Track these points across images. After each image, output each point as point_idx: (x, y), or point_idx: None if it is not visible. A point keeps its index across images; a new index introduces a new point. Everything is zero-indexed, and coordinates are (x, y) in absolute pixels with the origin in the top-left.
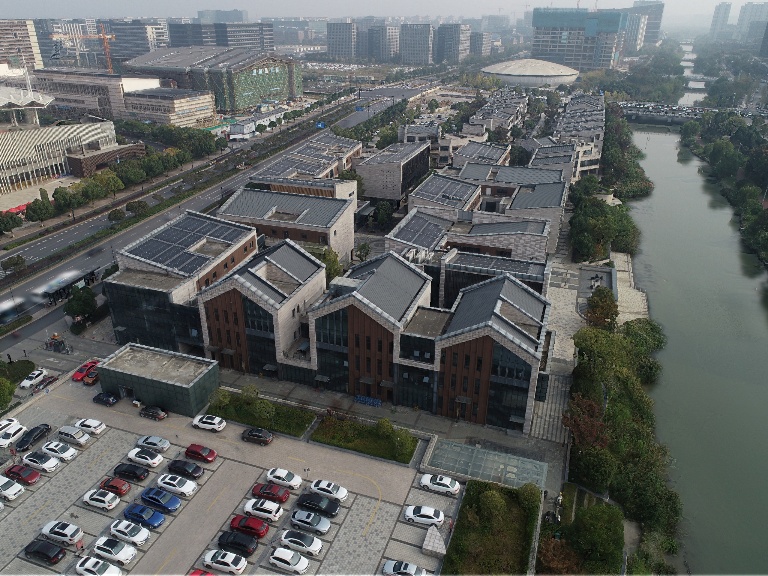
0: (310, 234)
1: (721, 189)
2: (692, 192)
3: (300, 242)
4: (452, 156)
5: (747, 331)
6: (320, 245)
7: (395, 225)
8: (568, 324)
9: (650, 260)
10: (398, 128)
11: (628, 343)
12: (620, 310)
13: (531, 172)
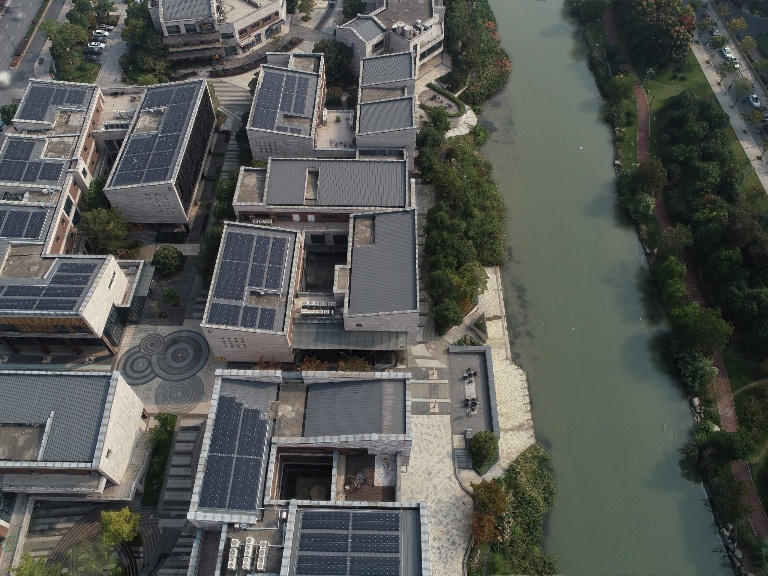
0: (70, 471)
1: (587, 50)
2: (555, 66)
3: (59, 477)
4: (241, 46)
5: (636, 423)
6: (92, 478)
7: (191, 284)
8: (449, 514)
9: (522, 275)
10: (148, 7)
11: (519, 532)
12: (501, 427)
13: (364, 171)
